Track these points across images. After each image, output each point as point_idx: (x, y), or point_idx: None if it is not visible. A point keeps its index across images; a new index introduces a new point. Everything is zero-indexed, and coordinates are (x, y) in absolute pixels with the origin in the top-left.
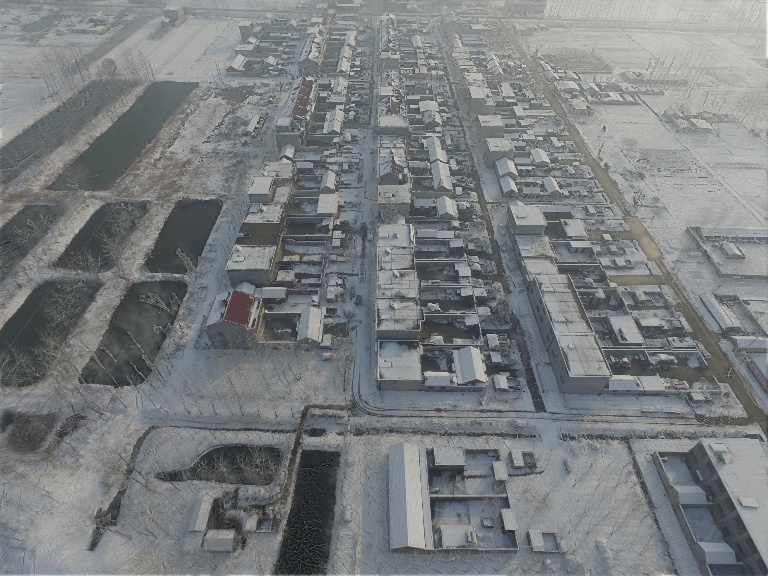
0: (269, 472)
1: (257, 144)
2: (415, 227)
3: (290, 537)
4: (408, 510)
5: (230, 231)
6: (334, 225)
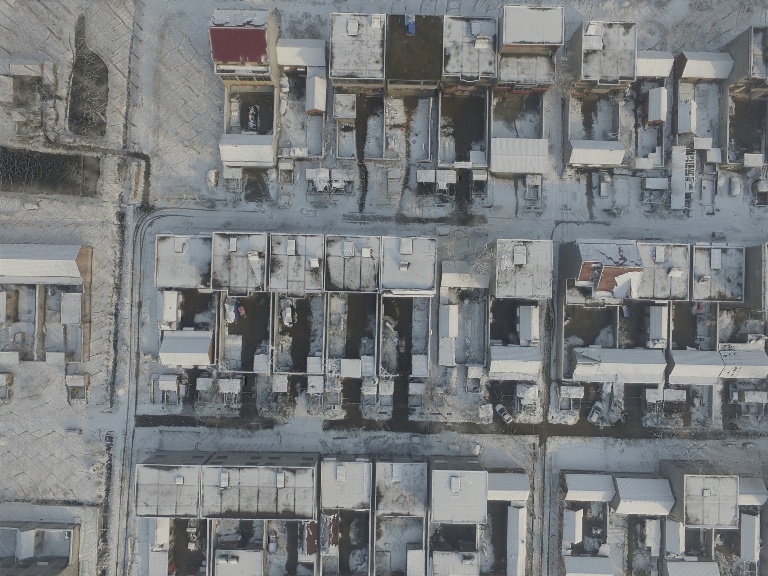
0: (81, 127)
1: (750, 1)
2: (475, 305)
3: (19, 155)
4: (8, 261)
5: (436, 3)
6: (472, 170)
